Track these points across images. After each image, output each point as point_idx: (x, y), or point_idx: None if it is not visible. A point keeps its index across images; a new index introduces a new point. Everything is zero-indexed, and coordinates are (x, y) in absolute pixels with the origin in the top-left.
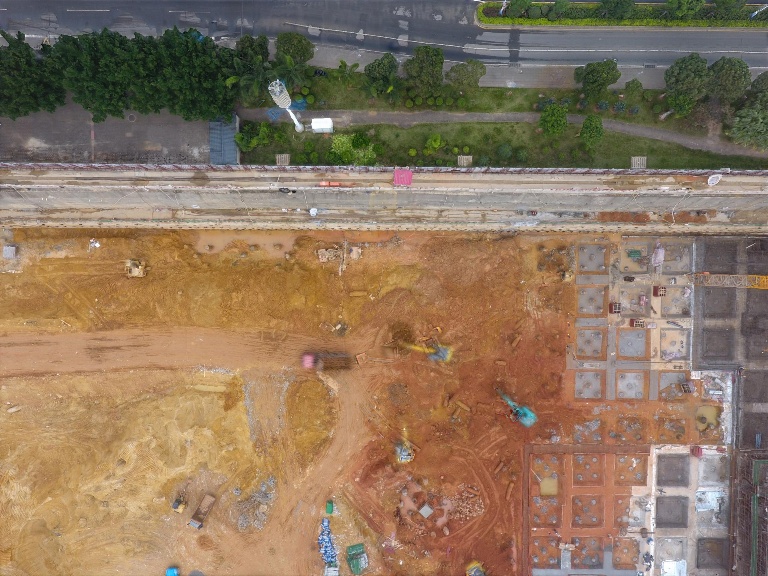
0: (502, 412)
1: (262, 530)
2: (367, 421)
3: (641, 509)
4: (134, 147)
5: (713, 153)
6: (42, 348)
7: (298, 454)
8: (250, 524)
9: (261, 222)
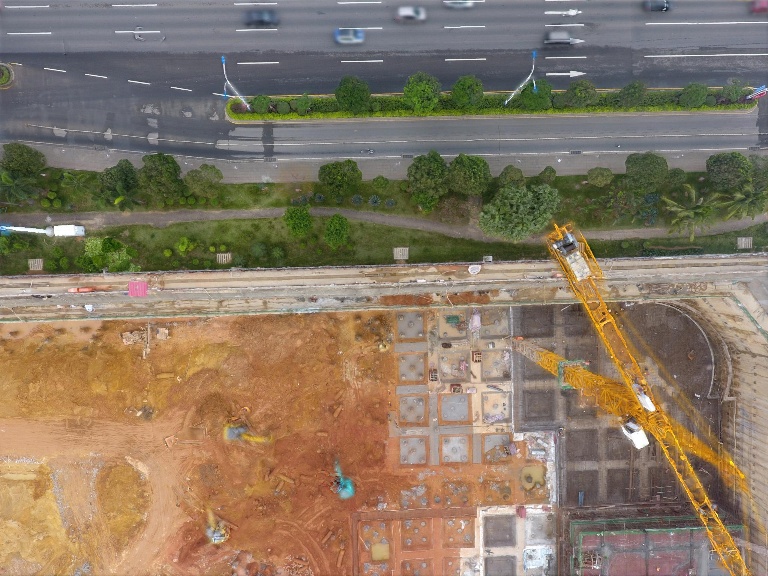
0: (326, 483)
1: None
2: (181, 503)
3: (471, 570)
4: None
5: (476, 241)
6: None
7: (113, 538)
8: None
9: (36, 320)
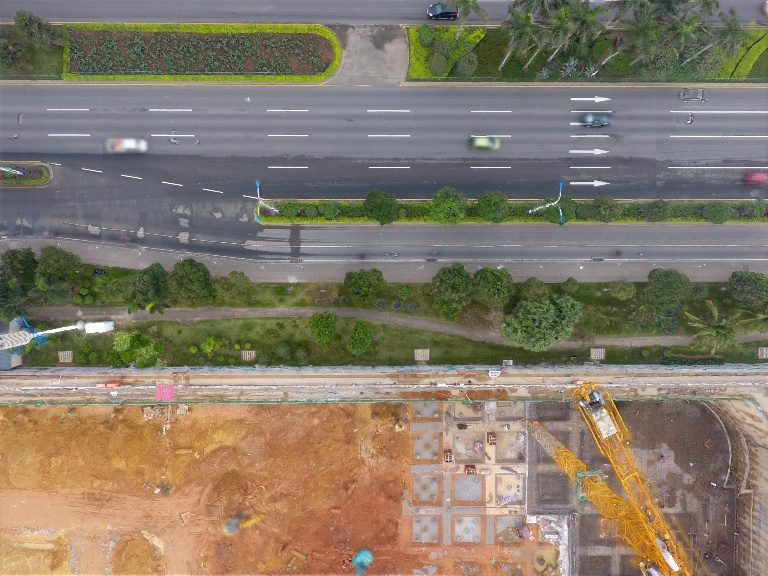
0: (337, 560)
1: None
2: None
3: None
4: None
5: (496, 344)
6: None
7: None
8: None
9: (62, 403)
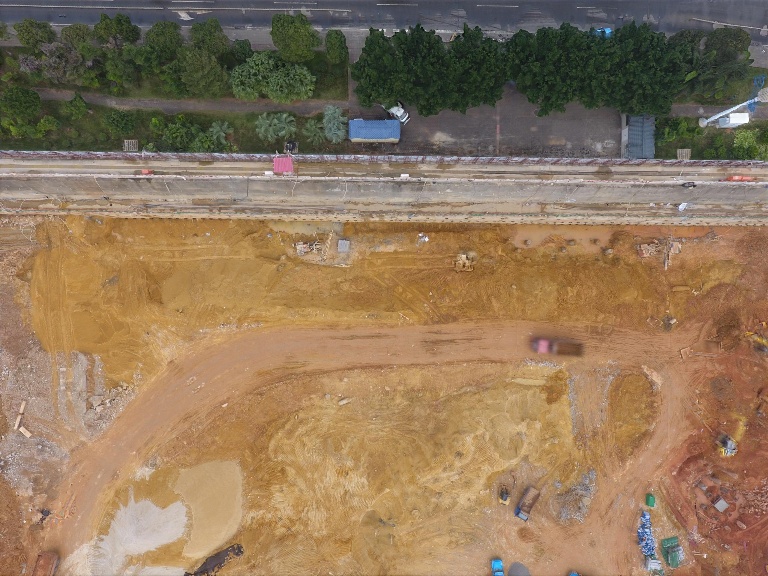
0: None
1: (583, 523)
2: (688, 415)
3: None
4: (538, 141)
5: None
6: (381, 341)
7: (617, 447)
8: (571, 517)
9: (629, 216)
